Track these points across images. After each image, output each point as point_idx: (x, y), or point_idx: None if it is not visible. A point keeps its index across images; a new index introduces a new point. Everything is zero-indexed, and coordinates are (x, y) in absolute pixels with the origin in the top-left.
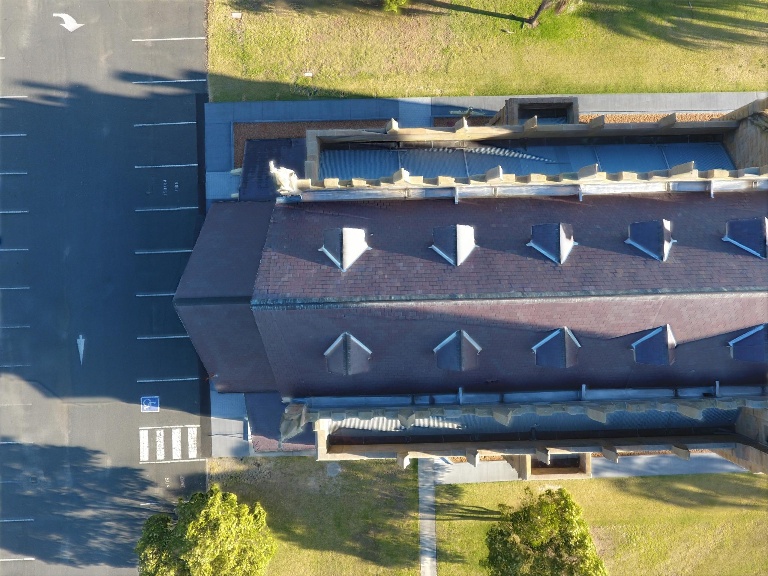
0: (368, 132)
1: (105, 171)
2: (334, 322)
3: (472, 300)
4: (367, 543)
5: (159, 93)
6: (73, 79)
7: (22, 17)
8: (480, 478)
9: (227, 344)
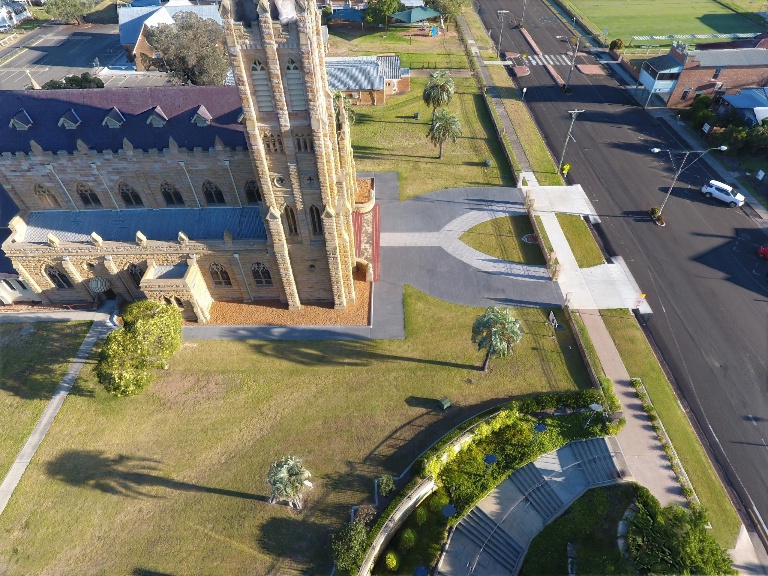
0: None
1: None
2: (18, 102)
3: None
4: (19, 380)
5: None
6: None
7: None
8: None
9: None
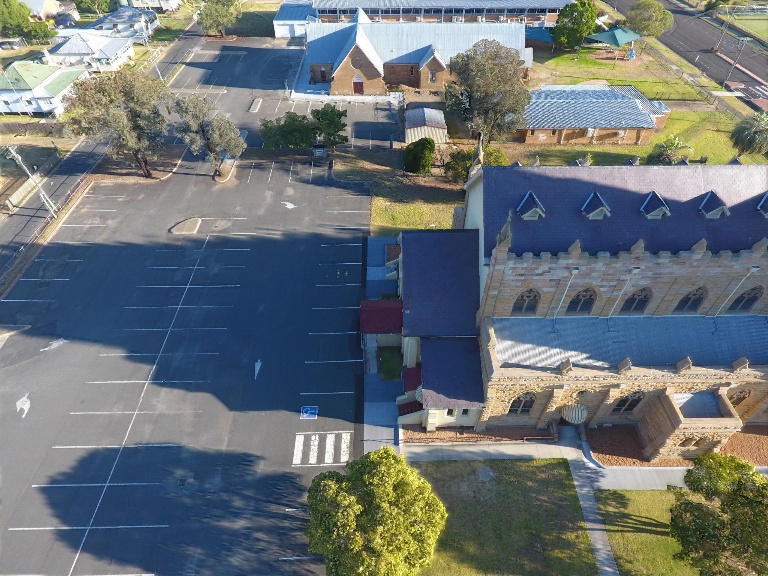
0: None
1: (298, 266)
2: (525, 182)
3: (599, 166)
4: (536, 559)
5: (339, 232)
6: (286, 226)
7: (262, 203)
8: (637, 485)
9: (425, 274)
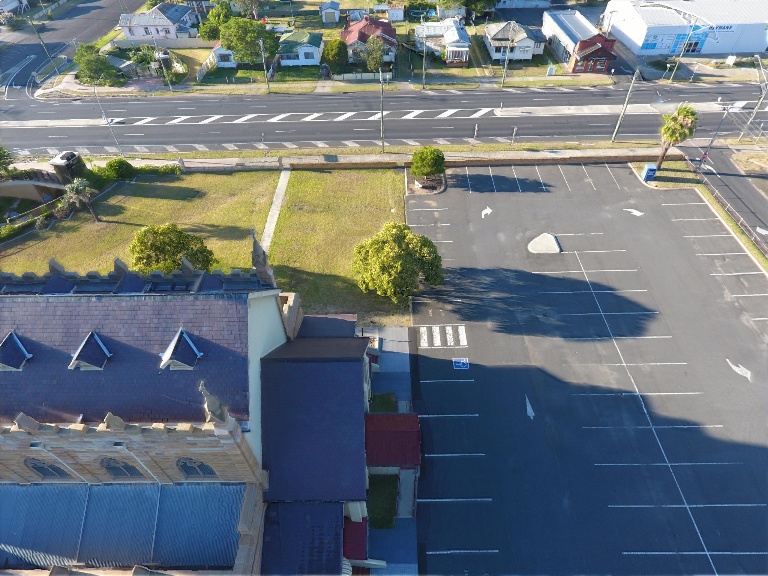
0: (171, 574)
1: None
2: None
3: (86, 296)
4: (298, 278)
5: None
6: None
7: None
8: None
9: None
